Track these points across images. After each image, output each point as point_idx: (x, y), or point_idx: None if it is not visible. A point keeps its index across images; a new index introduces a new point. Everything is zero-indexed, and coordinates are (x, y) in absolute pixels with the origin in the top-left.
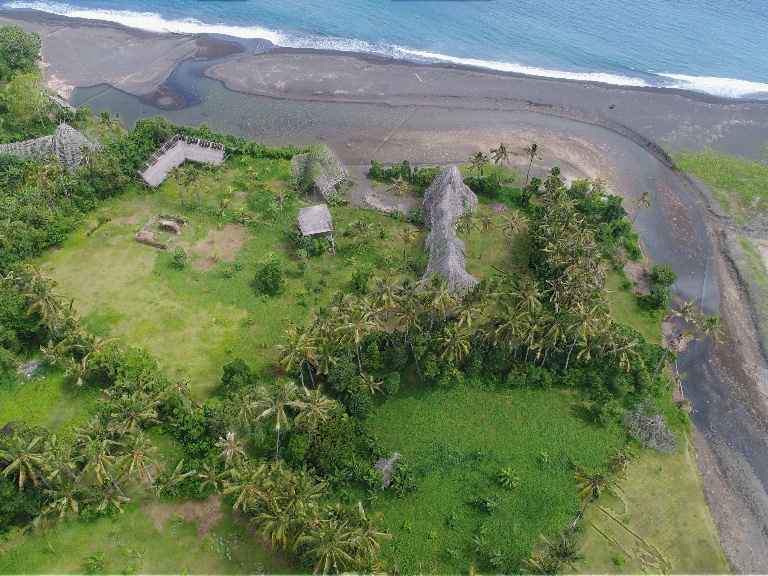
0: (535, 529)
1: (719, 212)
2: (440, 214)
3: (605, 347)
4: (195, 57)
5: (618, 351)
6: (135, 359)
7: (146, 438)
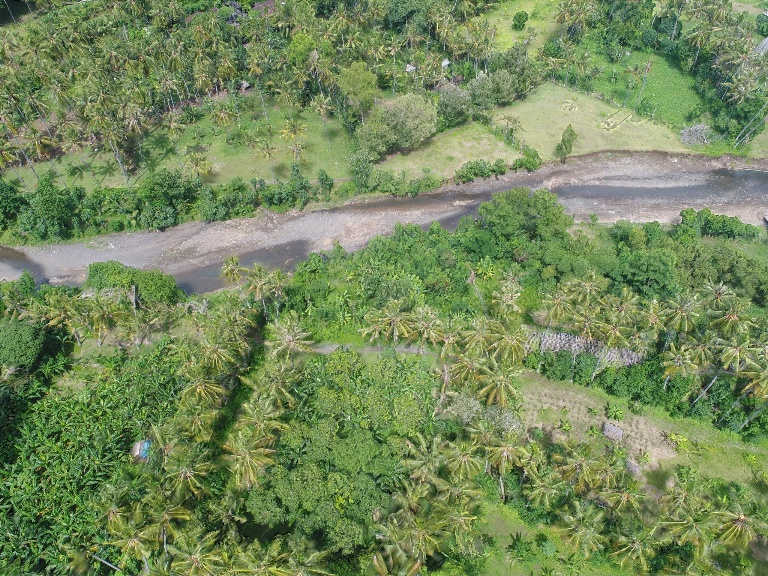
0: None
1: None
2: None
3: (737, 85)
4: None
5: None
6: None
7: None
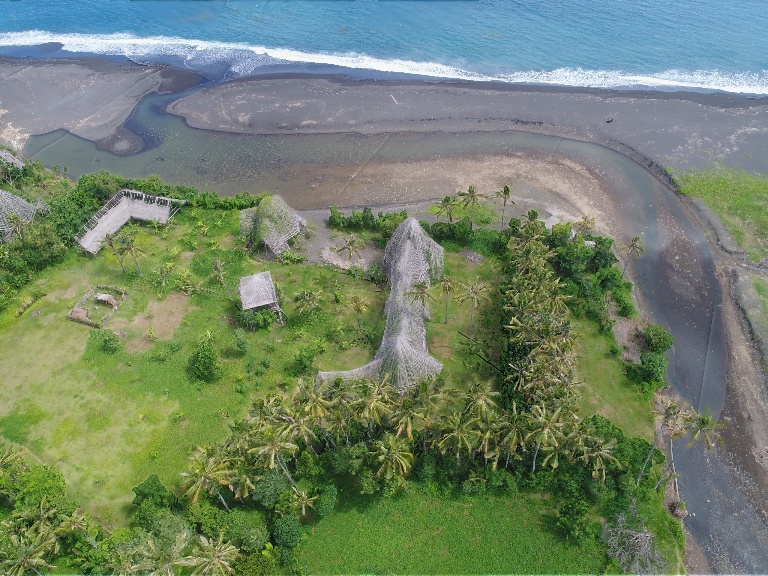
0: None
1: (730, 247)
2: (397, 276)
3: (575, 452)
4: (158, 91)
5: (591, 456)
6: (38, 481)
7: (51, 572)
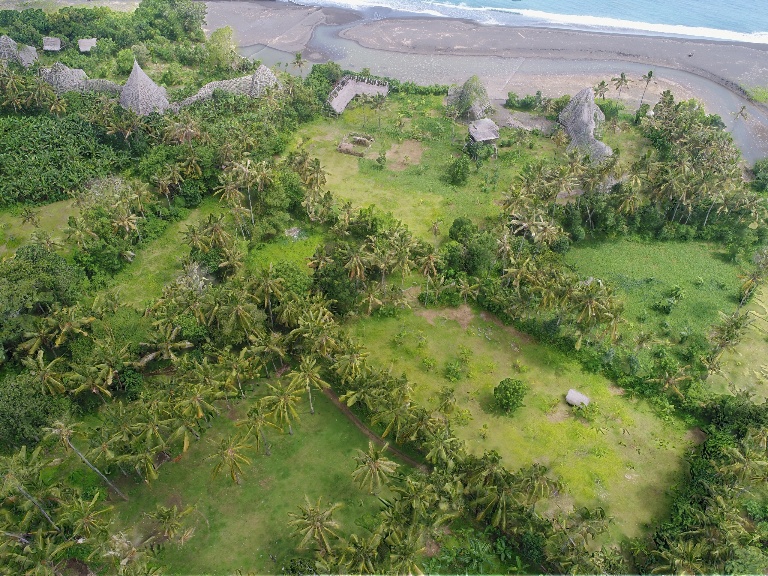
0: (704, 322)
1: None
2: (582, 125)
3: (739, 203)
4: (326, 23)
5: (749, 206)
6: (385, 217)
7: None
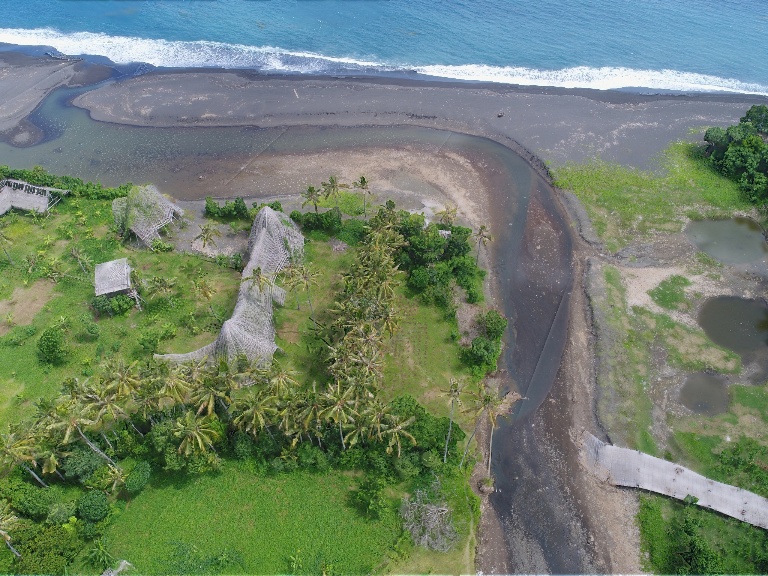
0: None
1: (590, 237)
2: None
3: (373, 429)
4: (68, 84)
5: (388, 433)
6: None
7: None
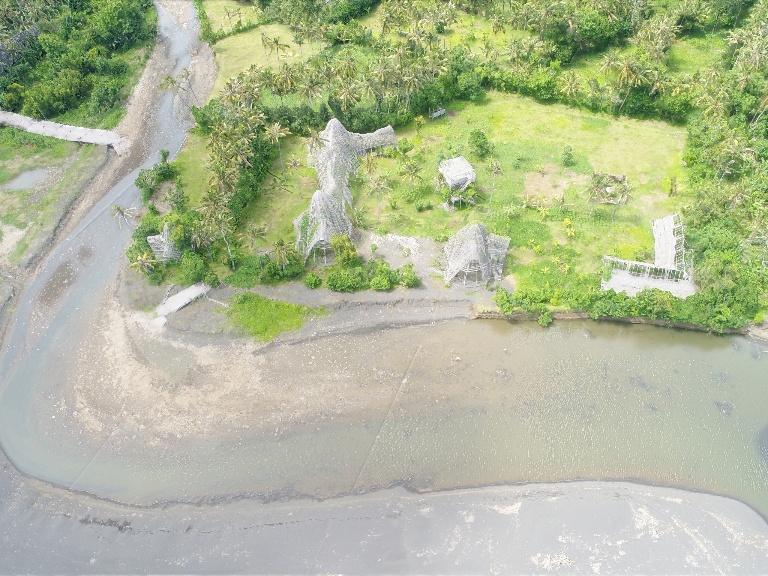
0: None
1: (7, 288)
2: None
3: None
4: None
5: None
6: None
7: None
